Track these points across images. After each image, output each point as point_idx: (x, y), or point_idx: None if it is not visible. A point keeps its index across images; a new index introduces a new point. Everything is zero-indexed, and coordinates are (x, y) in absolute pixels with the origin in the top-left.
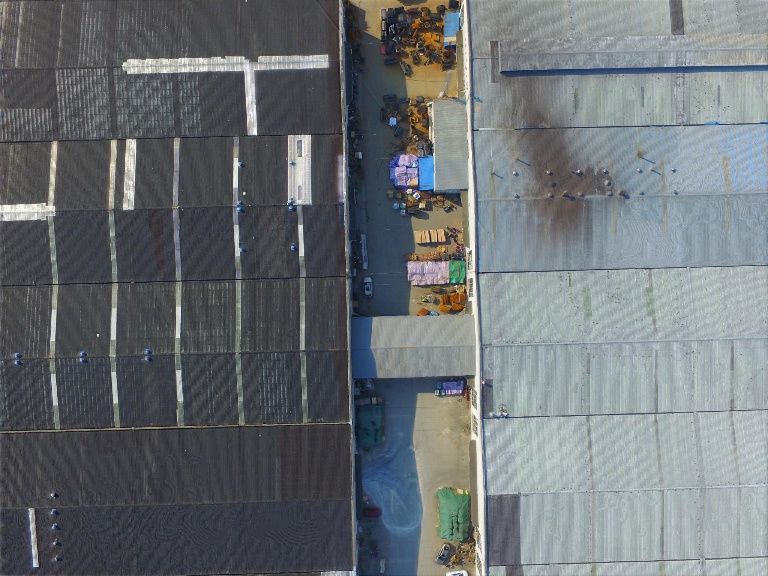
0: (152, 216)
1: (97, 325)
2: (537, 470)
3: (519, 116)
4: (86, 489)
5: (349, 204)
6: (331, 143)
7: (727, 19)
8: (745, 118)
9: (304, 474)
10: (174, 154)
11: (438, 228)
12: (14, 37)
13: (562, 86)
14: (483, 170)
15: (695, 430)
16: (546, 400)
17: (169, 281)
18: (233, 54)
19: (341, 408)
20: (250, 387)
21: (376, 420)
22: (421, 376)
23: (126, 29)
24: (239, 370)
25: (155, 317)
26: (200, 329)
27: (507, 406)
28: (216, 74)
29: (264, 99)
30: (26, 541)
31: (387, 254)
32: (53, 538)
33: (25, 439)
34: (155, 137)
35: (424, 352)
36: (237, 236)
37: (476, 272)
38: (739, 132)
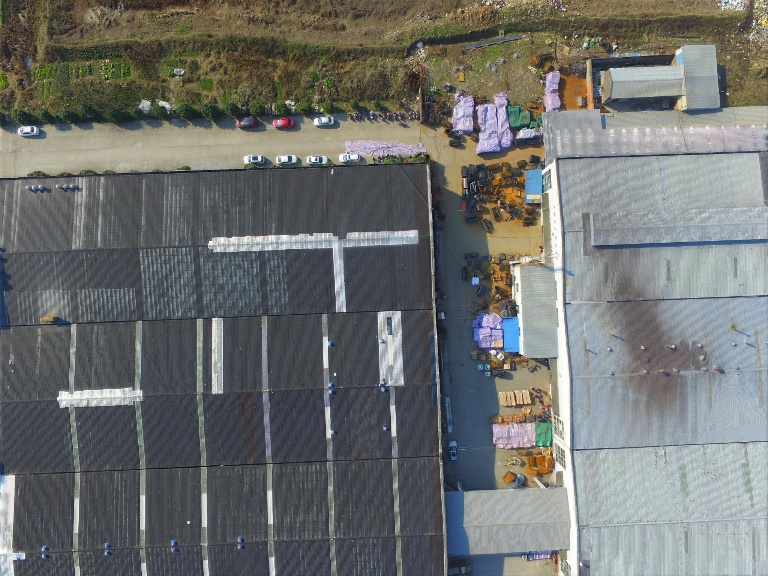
0: (241, 399)
1: (187, 512)
2: None
3: (612, 290)
4: None
5: None
6: (421, 319)
7: None
8: None
9: None
10: (262, 333)
11: (522, 388)
12: (95, 215)
13: (655, 258)
14: (576, 346)
15: None
16: None
17: (259, 464)
18: (321, 231)
19: None
20: (344, 572)
21: None
22: (514, 551)
23: (210, 205)
24: (333, 556)
25: (246, 502)
26: (292, 514)
27: None
28: (304, 251)
29: (353, 276)
30: None
31: (471, 416)
32: None
33: None
34: (242, 315)
35: (518, 529)
36: (328, 418)
37: (571, 450)
38: None
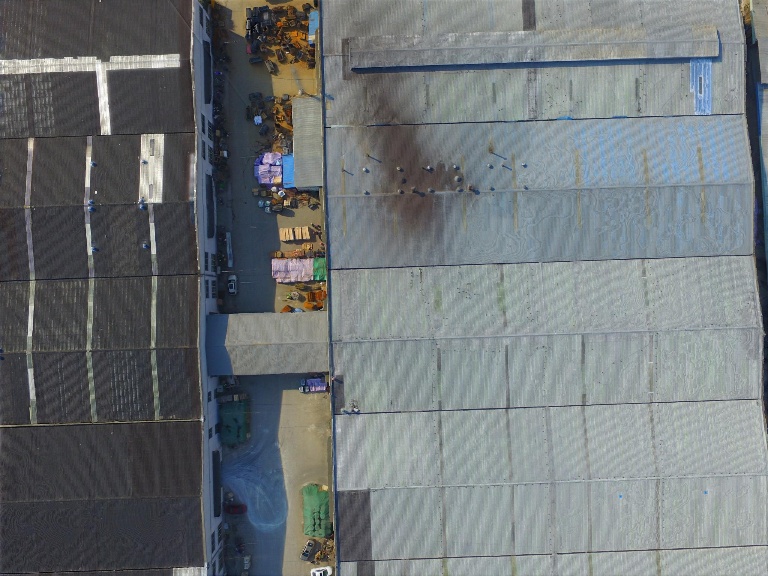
0: (5, 216)
1: None
2: (387, 466)
3: (370, 113)
4: None
5: (207, 202)
6: (184, 142)
7: (579, 14)
8: (598, 113)
9: (155, 471)
10: (28, 154)
11: (303, 225)
12: None
13: (413, 83)
14: (334, 167)
15: (546, 425)
16: (397, 396)
17: (23, 280)
18: (85, 54)
19: (193, 405)
20: (102, 385)
21: (238, 417)
22: (277, 373)
23: None
24: (90, 368)
25: (8, 316)
26: (52, 327)
27: (358, 402)
28: (68, 74)
29: (117, 99)
30: None
31: (253, 252)
32: None
33: None
34: (9, 137)
35: (278, 349)
36: (89, 235)
37: (327, 269)
38: (591, 127)
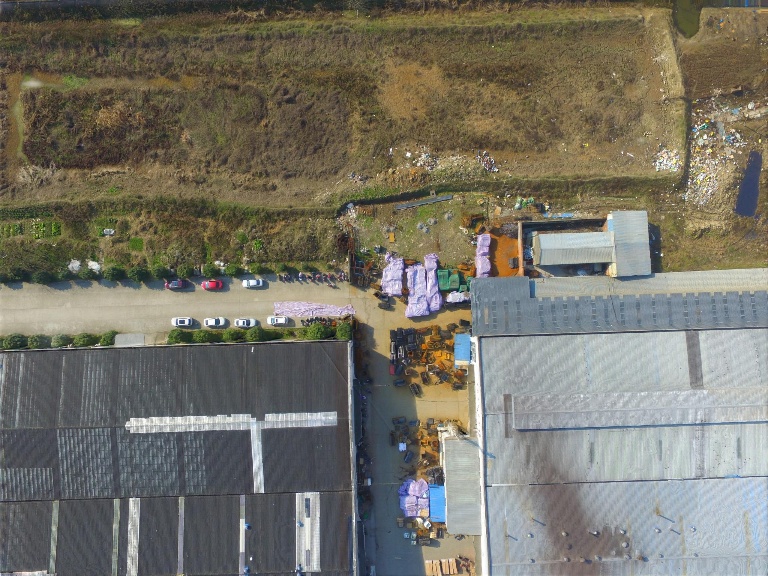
0: None
1: None
2: None
3: (534, 474)
4: None
5: (358, 551)
6: (340, 501)
7: (747, 367)
8: (766, 470)
9: None
10: (179, 515)
11: (450, 557)
12: (14, 393)
13: (578, 440)
14: (497, 531)
15: None
16: None
17: None
18: (239, 412)
19: None
20: None
21: None
22: None
23: (129, 384)
24: None
25: None
26: None
27: None
28: (222, 433)
29: (271, 457)
30: None
31: None
32: None
33: None
34: (159, 496)
35: None
36: None
37: None
38: (760, 485)
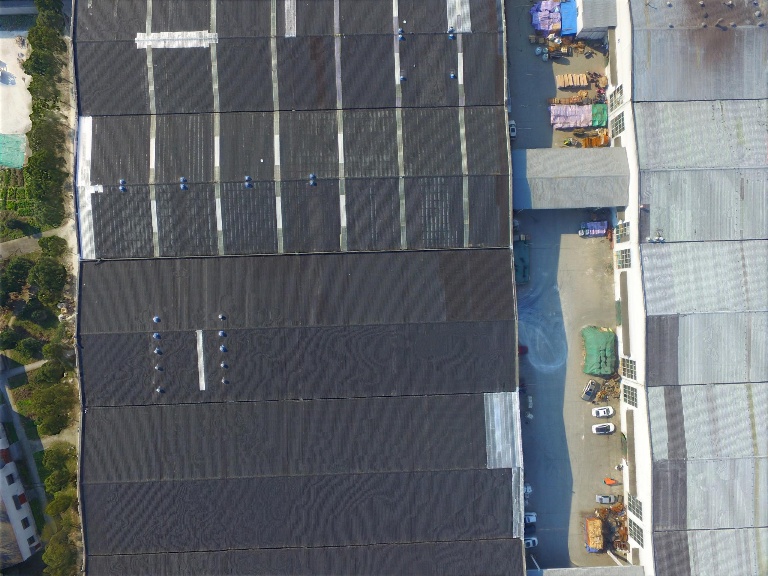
0: (314, 44)
1: (260, 151)
2: (694, 292)
3: None
4: (253, 311)
5: None
6: None
7: None
8: None
9: (467, 296)
10: None
11: (579, 73)
12: None
13: None
14: (637, 1)
15: None
16: (701, 225)
17: (330, 109)
18: None
19: (502, 233)
20: (413, 212)
21: (525, 257)
22: (574, 207)
23: None
24: (402, 195)
25: (318, 143)
26: (363, 155)
27: (663, 231)
28: None
29: None
30: (193, 363)
31: (529, 99)
32: (220, 360)
33: (189, 264)
34: None
35: (579, 182)
36: (398, 64)
37: (632, 100)
38: None
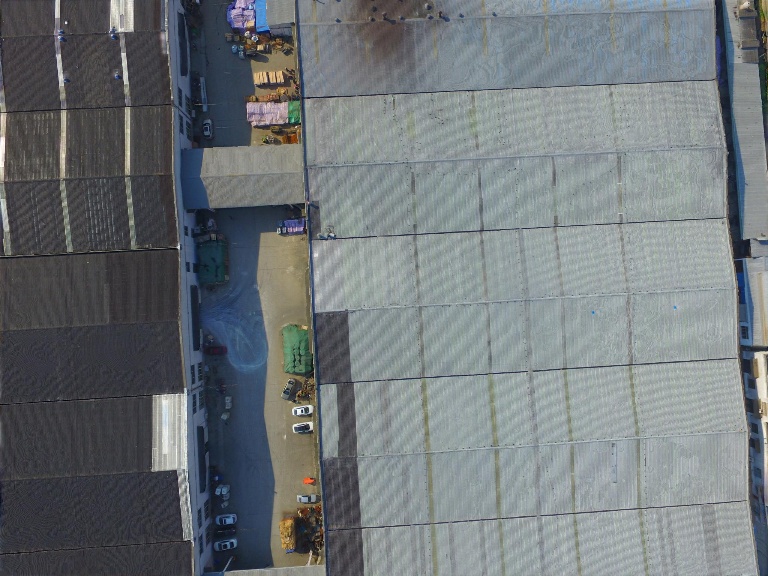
0: None
1: None
2: (364, 288)
3: None
4: None
5: (180, 40)
6: None
7: None
8: None
9: (132, 298)
10: None
11: (277, 70)
12: None
13: None
14: None
15: (520, 246)
16: (373, 220)
17: None
18: None
19: (169, 233)
20: (76, 214)
21: (216, 256)
22: (253, 205)
23: None
24: (64, 197)
25: None
26: (24, 158)
27: (334, 227)
28: None
29: None
30: None
31: (227, 97)
32: None
33: None
34: None
35: (254, 180)
36: (60, 66)
37: (301, 97)
38: None
